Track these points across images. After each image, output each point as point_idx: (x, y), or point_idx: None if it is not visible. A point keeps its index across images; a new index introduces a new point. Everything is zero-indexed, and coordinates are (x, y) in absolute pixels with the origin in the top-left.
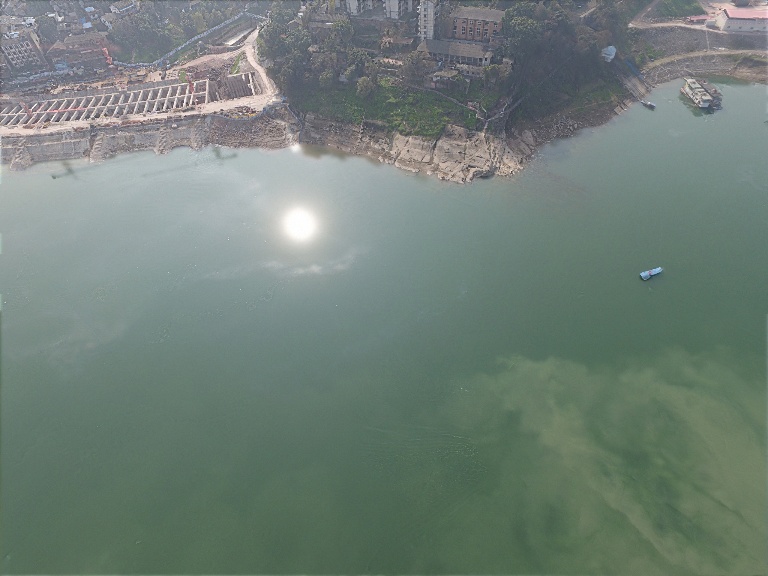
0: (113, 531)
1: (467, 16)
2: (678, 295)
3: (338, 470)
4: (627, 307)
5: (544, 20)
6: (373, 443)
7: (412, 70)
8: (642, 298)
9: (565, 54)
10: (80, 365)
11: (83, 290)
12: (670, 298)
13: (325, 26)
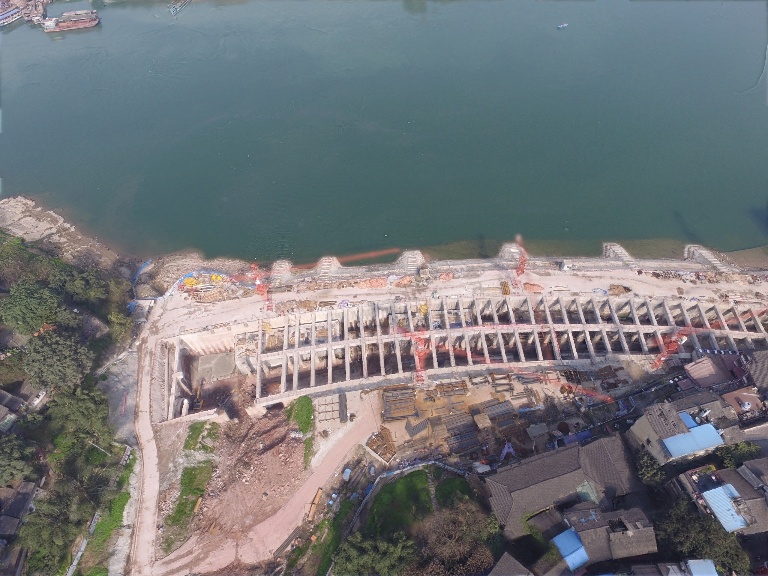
0: (307, 64)
1: None
2: None
3: None
4: (14, 116)
5: None
6: None
7: None
8: None
9: None
10: (336, 91)
11: (358, 131)
12: None
13: None
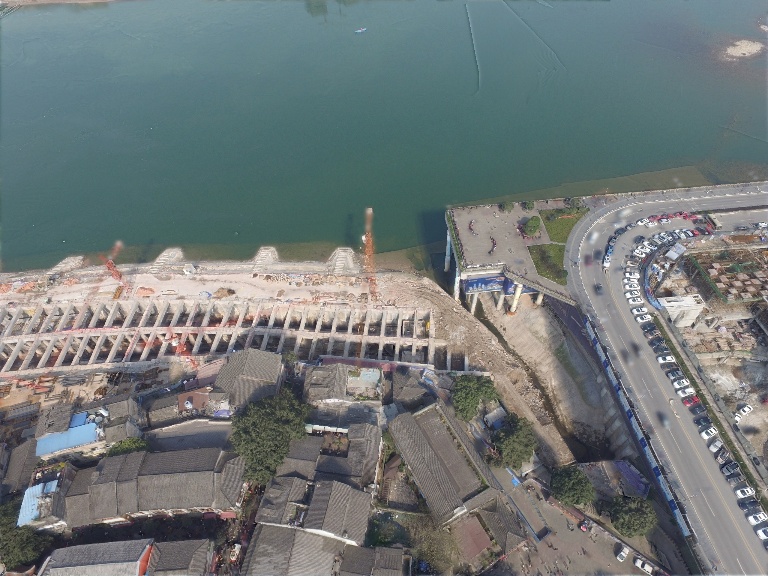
0: None
1: None
2: None
3: None
4: None
5: None
6: None
7: None
8: None
9: None
10: (98, 98)
11: (100, 138)
12: None
13: None
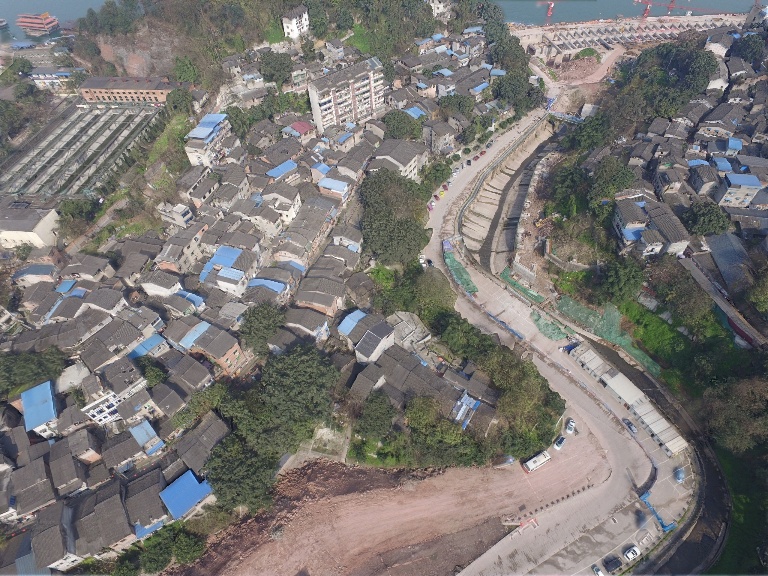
0: None
1: None
2: None
3: None
4: None
5: None
6: None
7: None
8: None
9: None
10: None
11: None
12: None
13: None
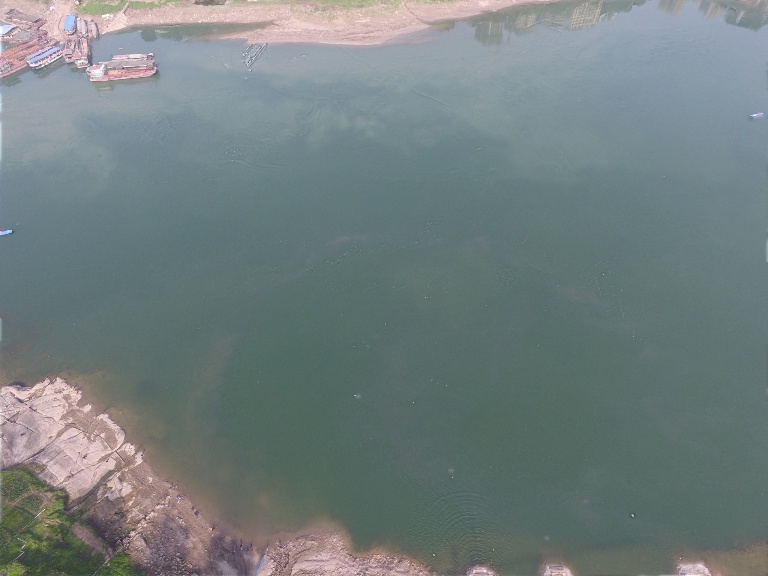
0: (429, 153)
1: None
2: (5, 214)
3: (303, 152)
4: (51, 217)
5: None
6: (280, 161)
7: None
8: (32, 221)
9: None
10: (487, 211)
11: (532, 284)
12: (14, 214)
13: None
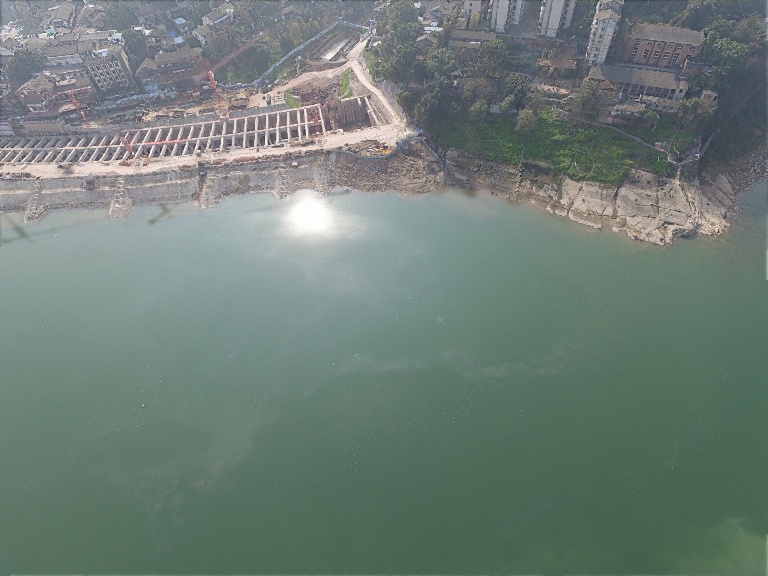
0: None
1: (654, 37)
2: None
3: None
4: None
5: (748, 42)
6: None
7: (591, 103)
8: None
9: (758, 80)
10: (261, 508)
11: (233, 388)
12: None
13: (469, 46)
